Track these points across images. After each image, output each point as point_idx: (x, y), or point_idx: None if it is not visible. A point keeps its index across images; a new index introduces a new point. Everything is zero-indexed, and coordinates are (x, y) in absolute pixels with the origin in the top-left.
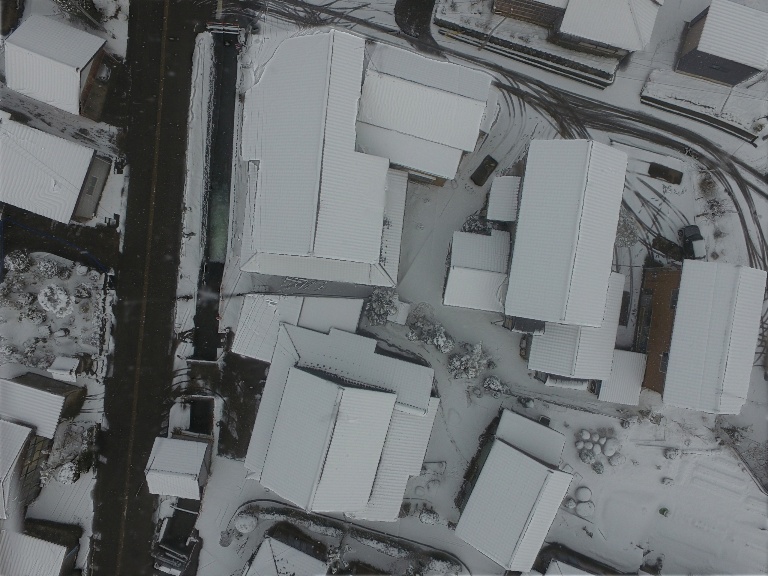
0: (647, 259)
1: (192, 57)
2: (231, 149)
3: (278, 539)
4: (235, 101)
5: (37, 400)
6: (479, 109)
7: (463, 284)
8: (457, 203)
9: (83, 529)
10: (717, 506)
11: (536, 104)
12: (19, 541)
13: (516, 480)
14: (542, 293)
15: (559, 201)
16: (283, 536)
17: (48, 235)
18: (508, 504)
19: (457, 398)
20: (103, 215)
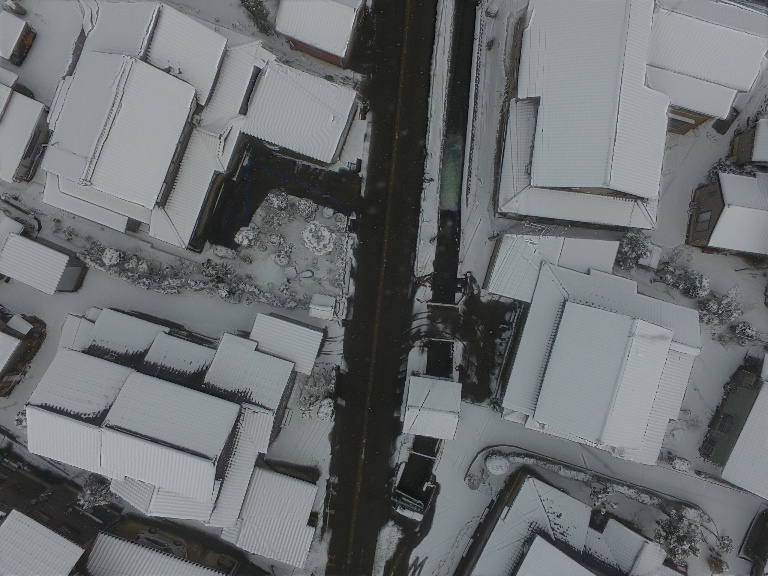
0: None
1: (436, 7)
2: (468, 98)
3: (539, 480)
4: (473, 51)
5: (297, 336)
6: (766, 46)
7: (734, 224)
8: (700, 151)
9: (320, 472)
10: None
11: None
12: (272, 478)
13: None
14: None
15: None
16: None
17: (291, 179)
18: None
19: (701, 346)
20: (346, 160)
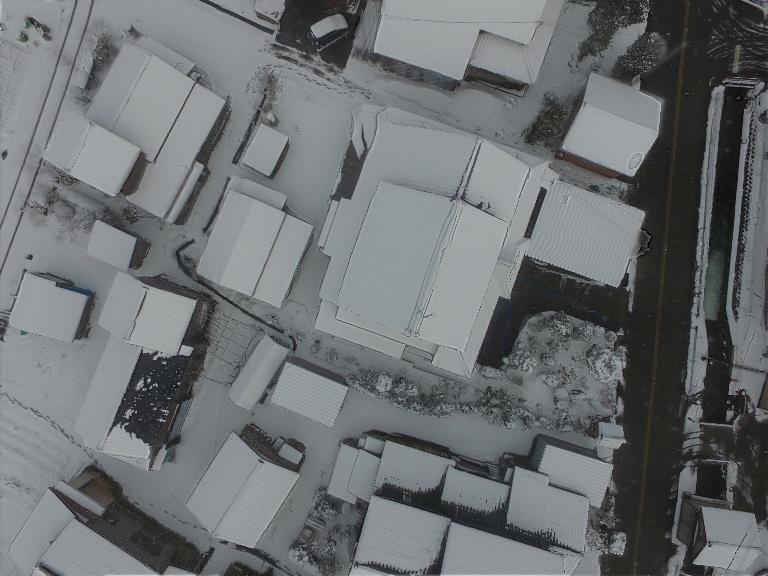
0: None
1: (708, 112)
2: (734, 205)
3: None
4: (739, 156)
5: (587, 468)
6: None
7: None
8: None
9: None
10: None
11: None
12: None
13: None
14: None
15: None
16: None
17: (556, 294)
18: None
19: None
20: None
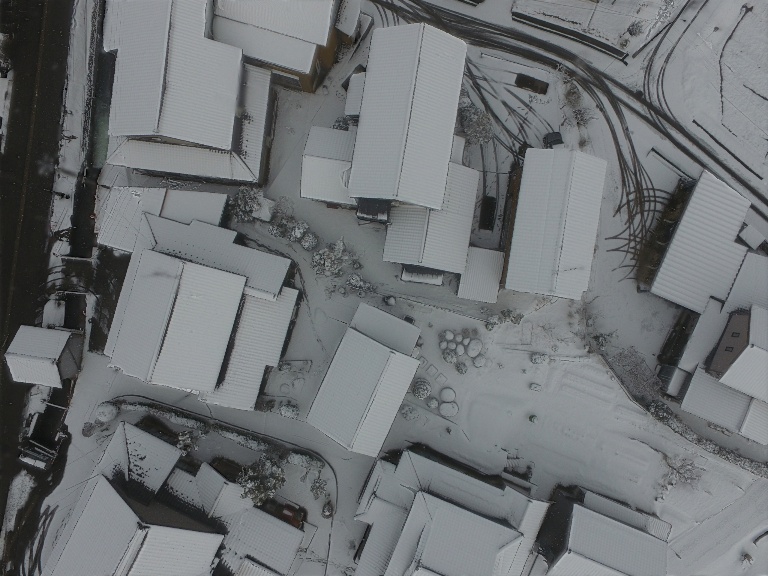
0: (513, 166)
1: None
2: (114, 58)
3: None
4: None
5: None
6: None
7: (316, 174)
8: (328, 109)
9: None
10: (587, 414)
11: (410, 19)
12: None
13: (362, 364)
14: (379, 172)
15: (395, 83)
16: (144, 427)
17: None
18: (354, 387)
19: (324, 298)
20: None
